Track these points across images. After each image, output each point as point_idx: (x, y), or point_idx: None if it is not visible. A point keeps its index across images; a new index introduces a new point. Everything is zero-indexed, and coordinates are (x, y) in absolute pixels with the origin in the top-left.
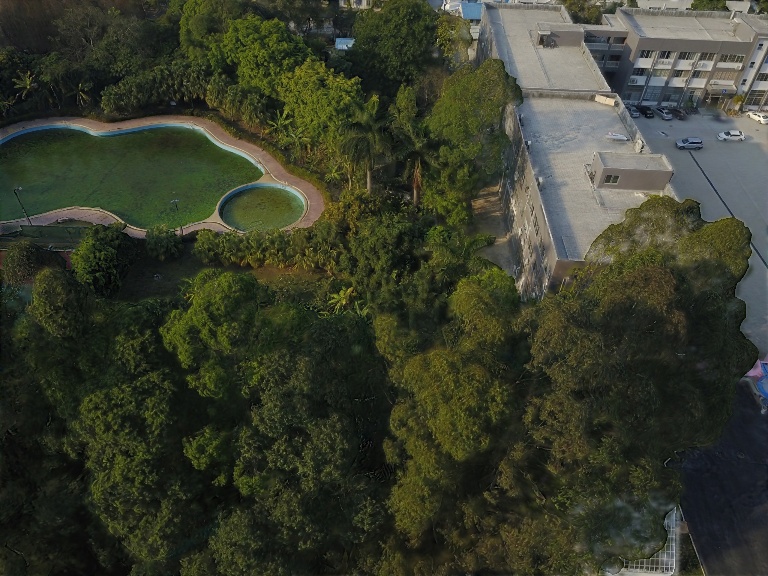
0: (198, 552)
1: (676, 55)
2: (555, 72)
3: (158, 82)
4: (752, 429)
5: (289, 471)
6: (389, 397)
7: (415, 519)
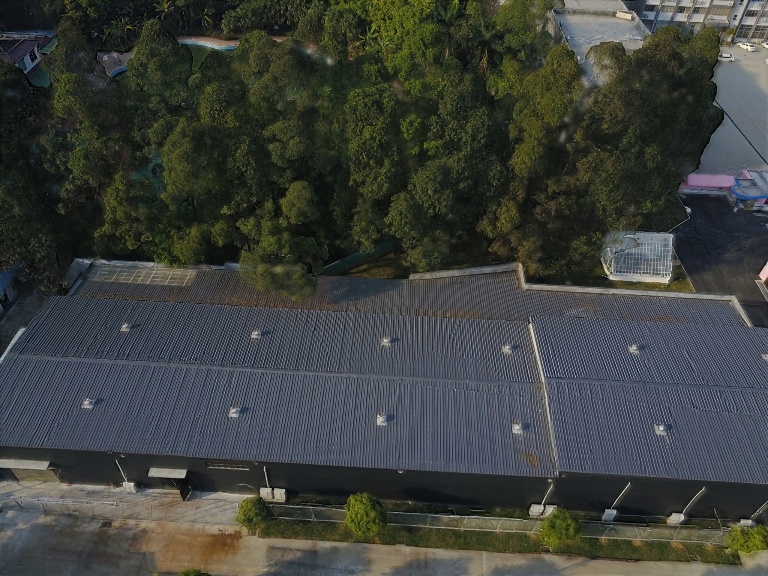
0: (403, 191)
1: None
2: (584, 0)
3: (268, 8)
4: (727, 219)
5: (456, 141)
6: (503, 124)
7: (528, 163)
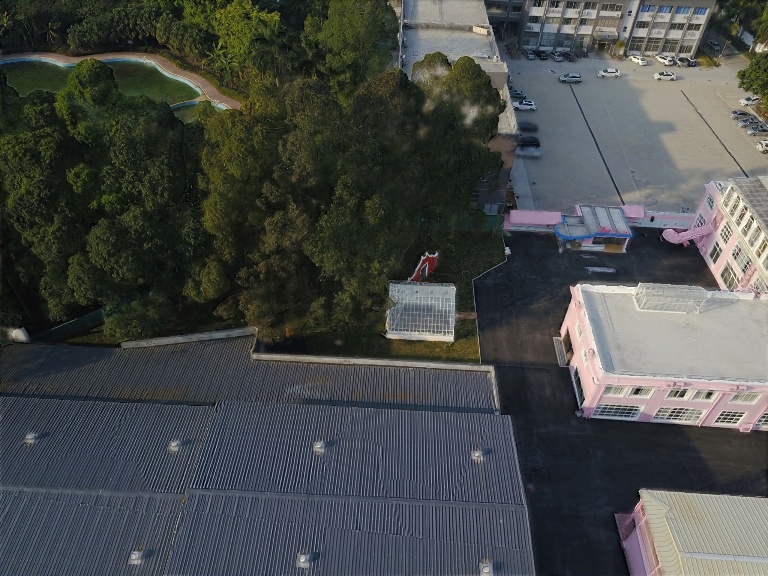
0: (79, 252)
1: (564, 4)
2: (450, 13)
3: (116, 22)
4: (548, 261)
5: (137, 195)
6: None
7: (215, 222)
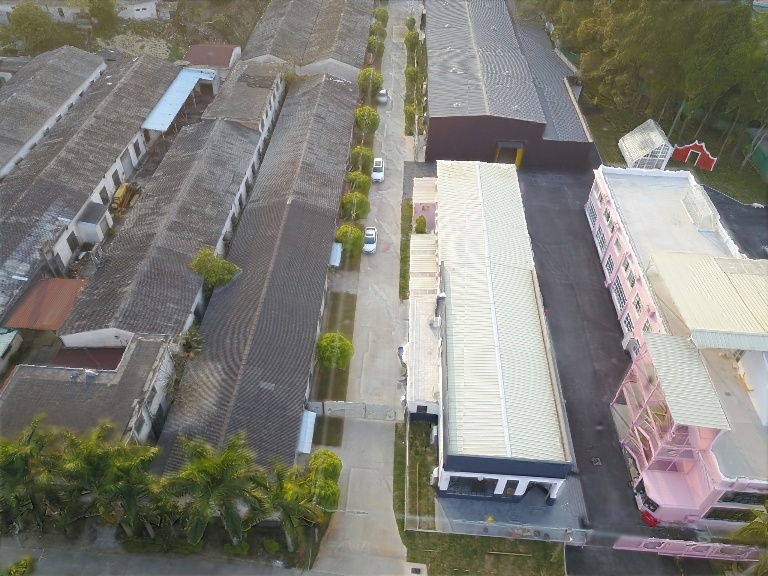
0: None
1: None
2: None
3: None
4: (761, 227)
5: None
6: None
7: None
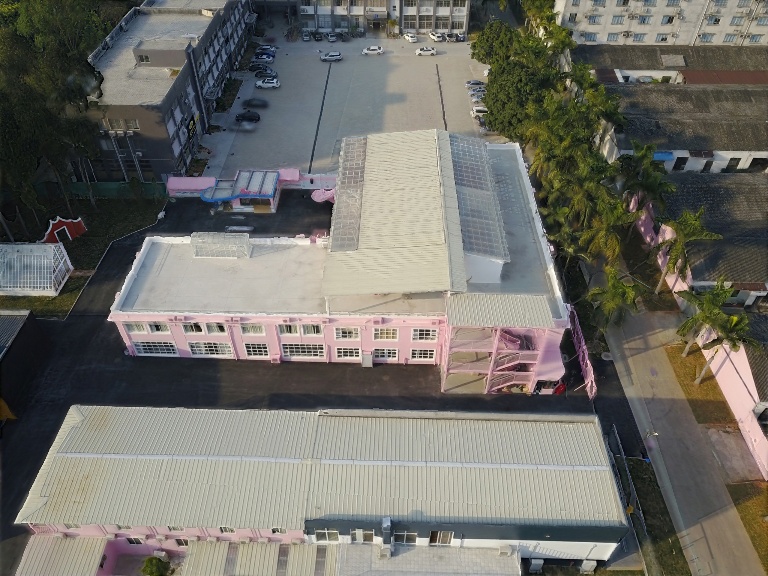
0: None
1: None
2: None
3: None
4: (196, 223)
5: None
6: None
7: None
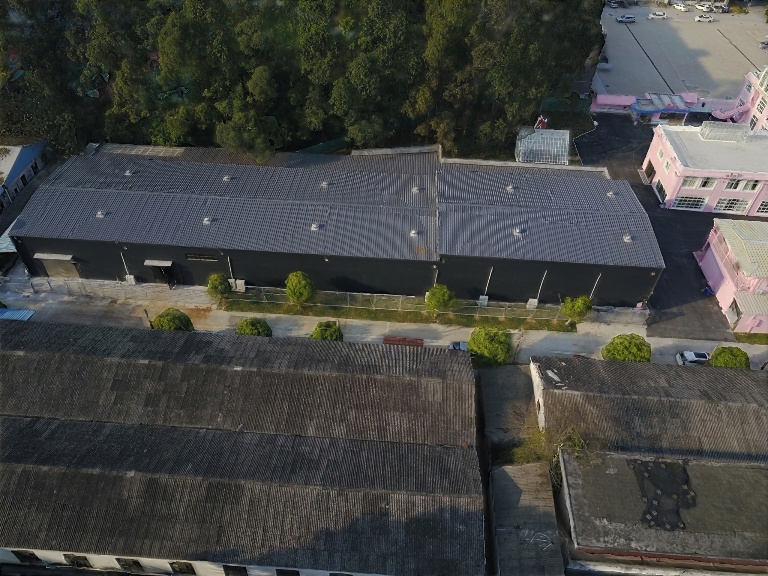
0: None
1: None
2: None
3: None
4: (627, 130)
5: (383, 38)
6: None
7: (436, 54)
